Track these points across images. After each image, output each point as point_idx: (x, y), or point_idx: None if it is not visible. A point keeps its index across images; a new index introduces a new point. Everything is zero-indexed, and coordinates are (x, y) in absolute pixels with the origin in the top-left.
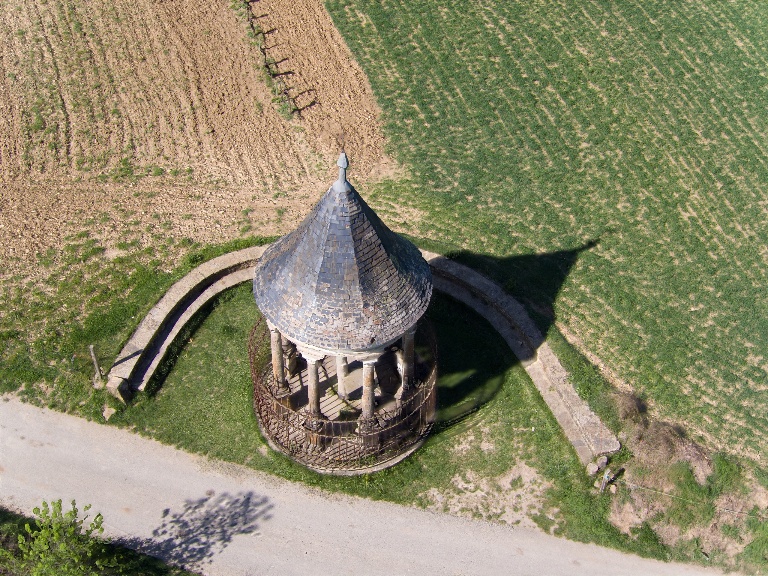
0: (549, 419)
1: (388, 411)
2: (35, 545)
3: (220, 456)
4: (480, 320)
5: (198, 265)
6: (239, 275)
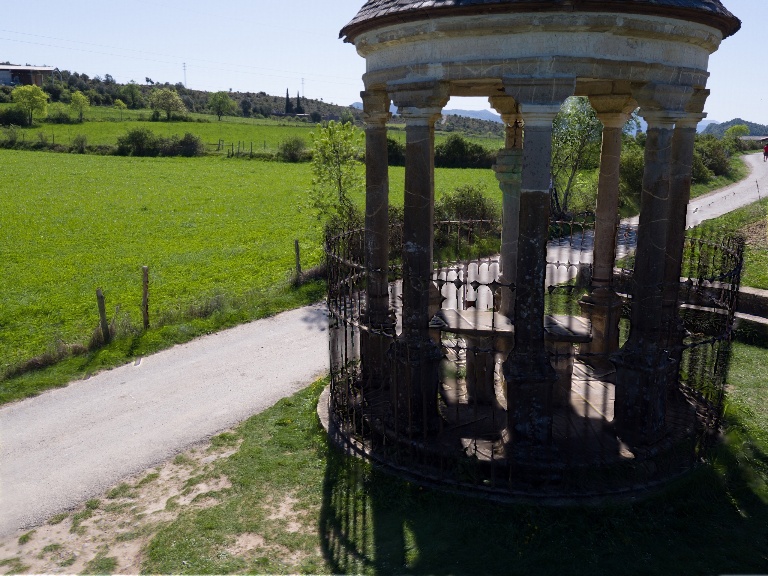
0: None
1: None
2: None
3: None
4: None
5: None
6: None
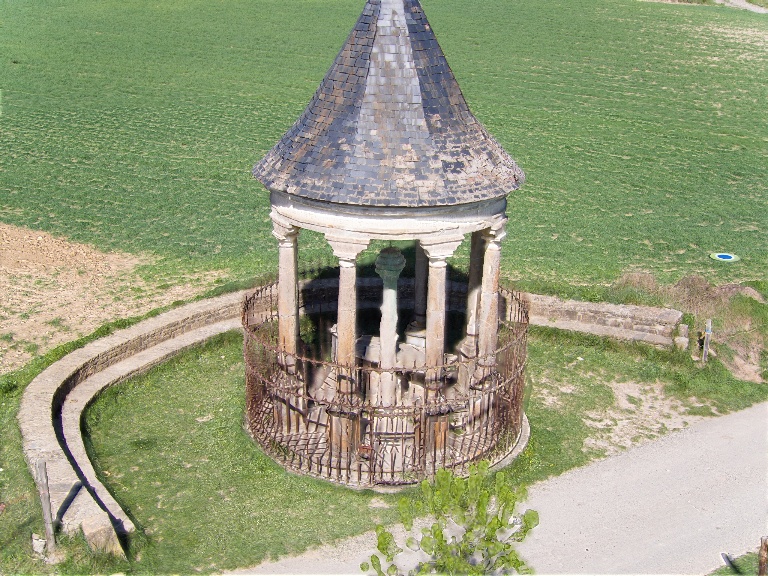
0: (585, 341)
1: (454, 398)
2: (460, 574)
3: (342, 535)
4: (407, 313)
5: (22, 390)
6: (85, 388)
